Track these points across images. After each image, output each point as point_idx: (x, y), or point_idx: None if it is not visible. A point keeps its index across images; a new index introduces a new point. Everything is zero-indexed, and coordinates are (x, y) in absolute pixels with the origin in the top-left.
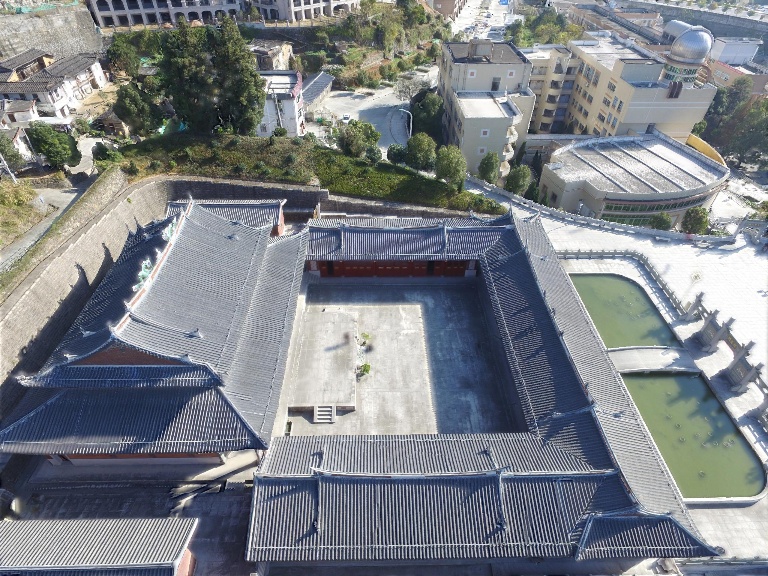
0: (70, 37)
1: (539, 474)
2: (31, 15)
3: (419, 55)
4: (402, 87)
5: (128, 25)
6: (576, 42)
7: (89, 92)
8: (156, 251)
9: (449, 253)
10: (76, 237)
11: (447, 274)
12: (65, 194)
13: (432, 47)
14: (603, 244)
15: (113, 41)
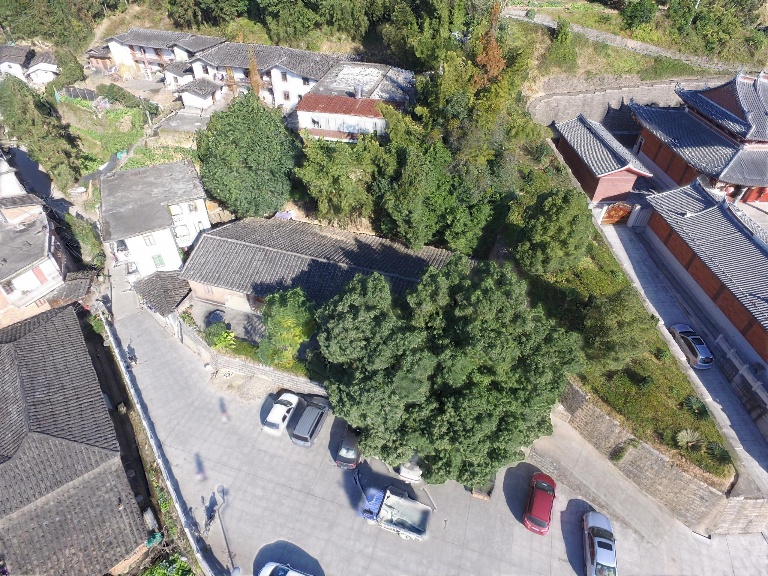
0: None
1: None
2: None
3: None
4: None
5: None
6: None
7: None
8: None
9: None
10: None
11: None
12: None
13: None
14: None
15: None
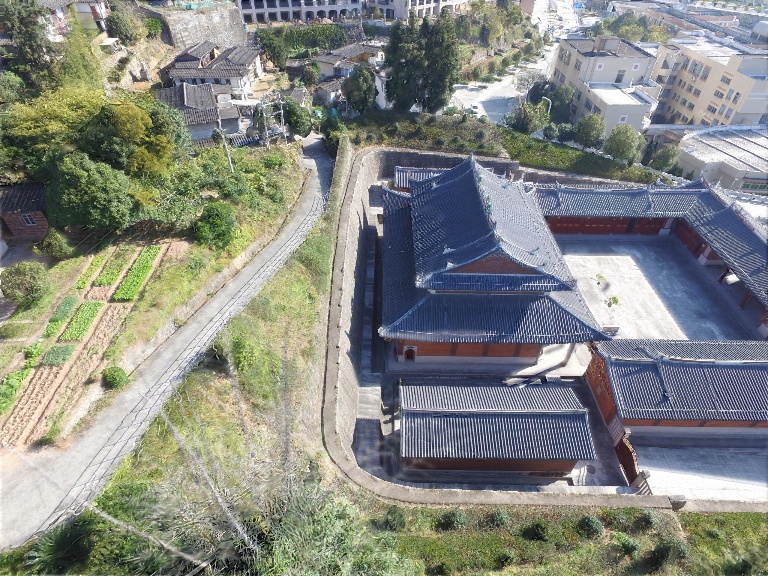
0: (223, 32)
1: None
2: (198, 11)
3: (520, 53)
4: (521, 80)
5: (265, 22)
6: (676, 40)
7: (252, 80)
8: (483, 190)
9: (656, 211)
10: (351, 190)
11: (643, 232)
12: (306, 159)
13: (529, 45)
14: (759, 214)
15: (256, 36)
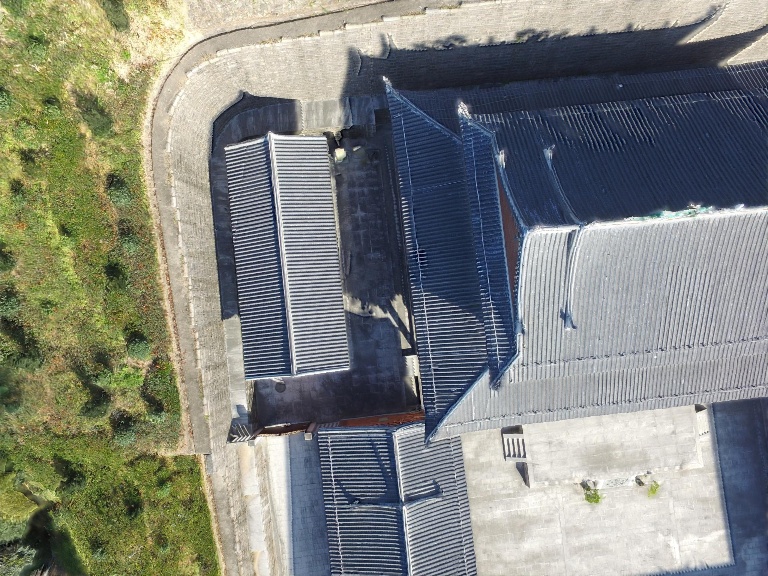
0: None
1: None
2: None
3: None
4: None
5: None
6: None
7: None
8: (738, 205)
9: None
10: None
11: None
12: None
13: None
14: None
15: None
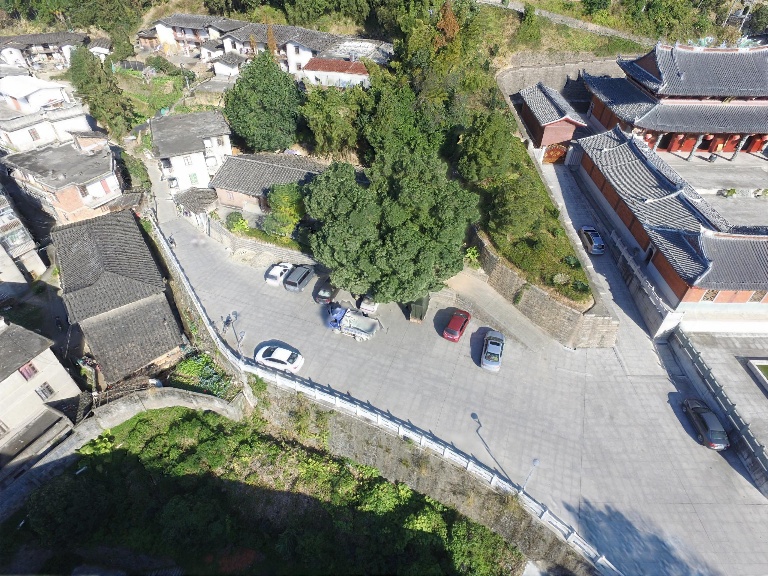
0: None
1: (694, 205)
2: None
3: None
4: None
5: None
6: None
7: None
8: None
9: None
10: None
11: None
12: None
13: None
14: None
15: None
